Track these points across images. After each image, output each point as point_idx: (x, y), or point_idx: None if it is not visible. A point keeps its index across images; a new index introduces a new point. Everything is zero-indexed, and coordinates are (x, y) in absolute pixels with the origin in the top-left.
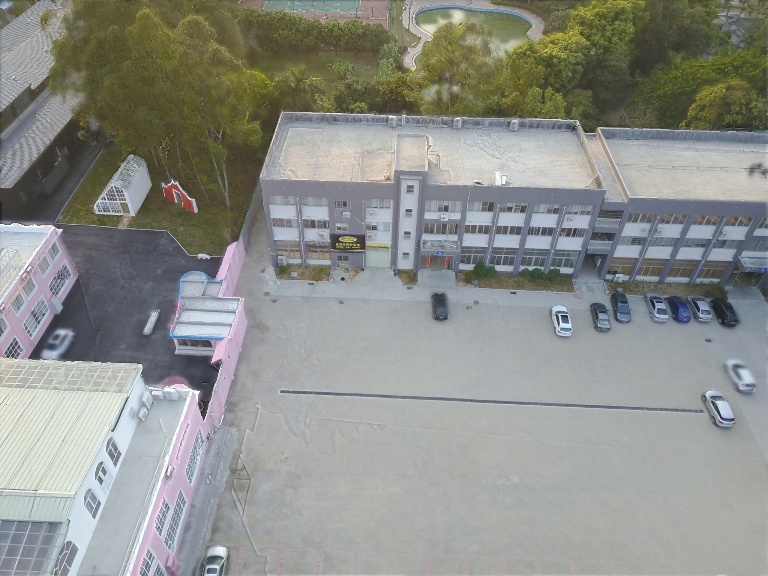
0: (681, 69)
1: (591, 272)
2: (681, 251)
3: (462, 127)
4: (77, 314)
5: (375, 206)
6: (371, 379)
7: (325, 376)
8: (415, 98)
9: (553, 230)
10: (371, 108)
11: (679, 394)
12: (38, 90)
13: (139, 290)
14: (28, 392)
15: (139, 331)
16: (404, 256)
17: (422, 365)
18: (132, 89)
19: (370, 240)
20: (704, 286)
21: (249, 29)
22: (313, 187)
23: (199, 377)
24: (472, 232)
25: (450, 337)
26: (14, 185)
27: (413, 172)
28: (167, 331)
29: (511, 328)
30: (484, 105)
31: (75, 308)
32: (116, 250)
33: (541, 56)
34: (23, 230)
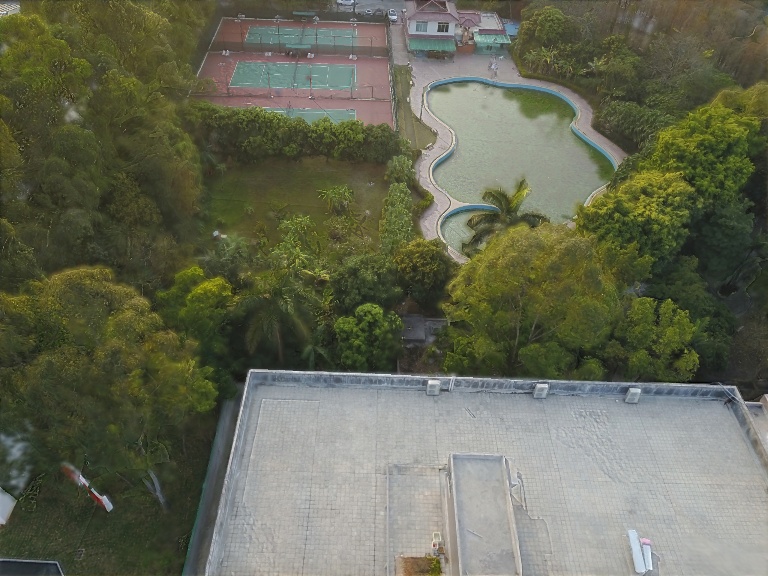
0: None
1: None
2: None
3: (547, 395)
4: None
5: None
6: None
7: None
8: (462, 318)
9: None
10: (387, 304)
11: None
12: None
13: None
14: None
15: None
16: None
17: None
18: None
19: None
20: None
21: (208, 135)
22: None
23: None
24: None
25: None
26: None
27: None
28: None
29: None
30: (575, 342)
31: None
32: None
33: (635, 220)
34: None
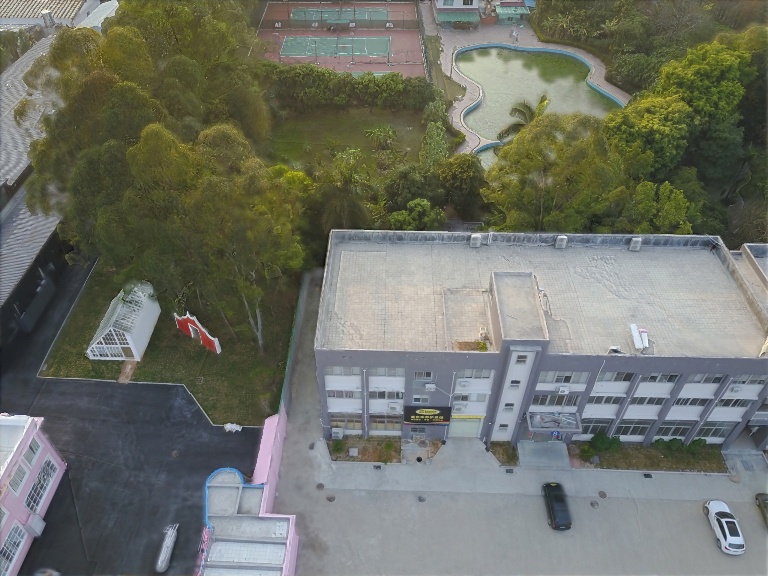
0: None
1: (744, 439)
2: None
3: (566, 246)
4: (65, 534)
5: (469, 376)
6: None
7: None
8: (496, 199)
9: (708, 400)
10: (432, 202)
11: None
12: (17, 184)
13: (149, 488)
14: None
15: (151, 564)
16: (501, 428)
17: None
18: (136, 225)
19: (458, 412)
20: None
21: (270, 88)
22: (387, 358)
23: None
24: (596, 402)
25: (577, 558)
26: None
27: (529, 342)
28: (190, 563)
29: (657, 539)
30: (589, 211)
31: (62, 523)
32: (117, 419)
33: (640, 131)
34: None
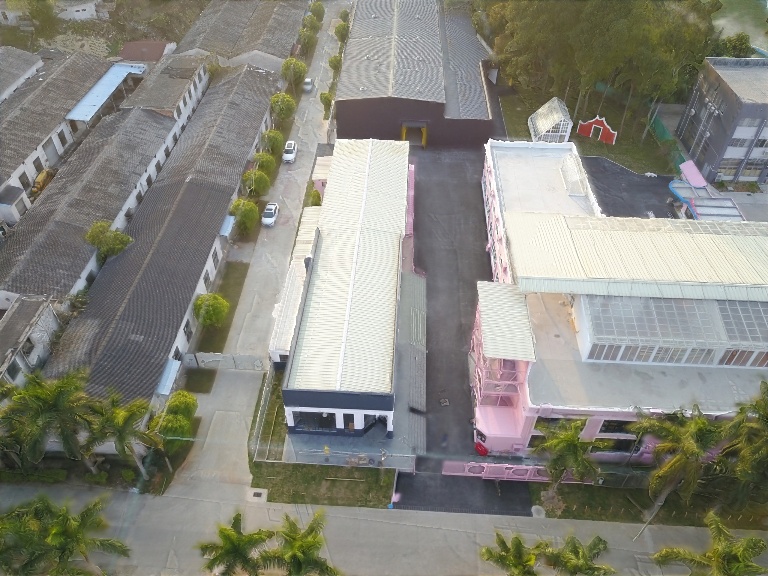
0: None
1: None
2: None
3: None
4: None
5: None
6: None
7: None
8: None
9: None
10: None
11: None
12: None
13: (621, 198)
14: (724, 236)
15: None
16: None
17: None
18: (633, 33)
19: None
20: None
21: None
22: None
23: None
24: None
25: None
26: (492, 118)
27: None
28: None
29: None
30: None
31: None
32: None
33: None
34: (547, 146)
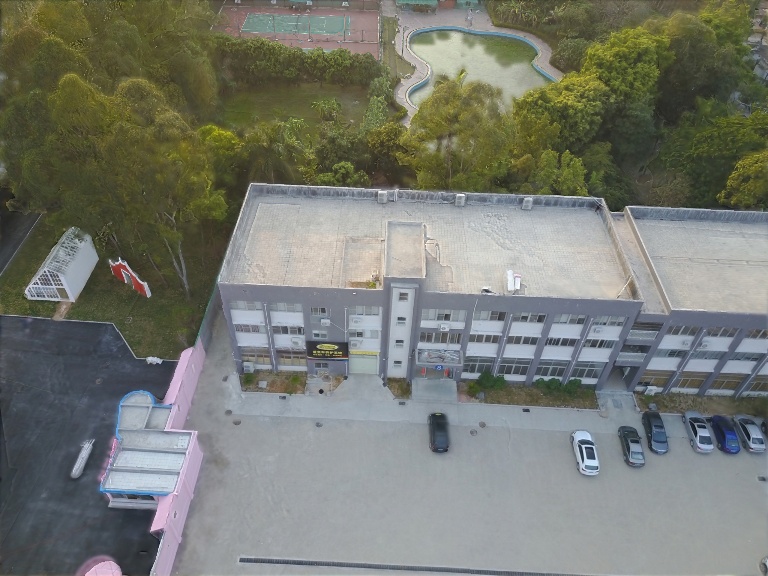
0: (717, 126)
1: (617, 381)
2: (728, 364)
3: (465, 204)
4: None
5: (360, 313)
6: (353, 540)
7: (296, 535)
8: (410, 162)
9: (576, 341)
10: (358, 166)
11: (732, 559)
12: None
13: (71, 409)
14: None
15: (66, 472)
16: (395, 365)
17: (417, 518)
18: (59, 168)
19: (354, 348)
20: (751, 400)
21: (222, 59)
22: (284, 293)
23: (137, 543)
24: (478, 341)
25: (451, 475)
26: None
27: (407, 279)
28: (101, 471)
29: (525, 462)
30: (491, 174)
31: None
32: (48, 351)
33: (555, 106)
34: None
